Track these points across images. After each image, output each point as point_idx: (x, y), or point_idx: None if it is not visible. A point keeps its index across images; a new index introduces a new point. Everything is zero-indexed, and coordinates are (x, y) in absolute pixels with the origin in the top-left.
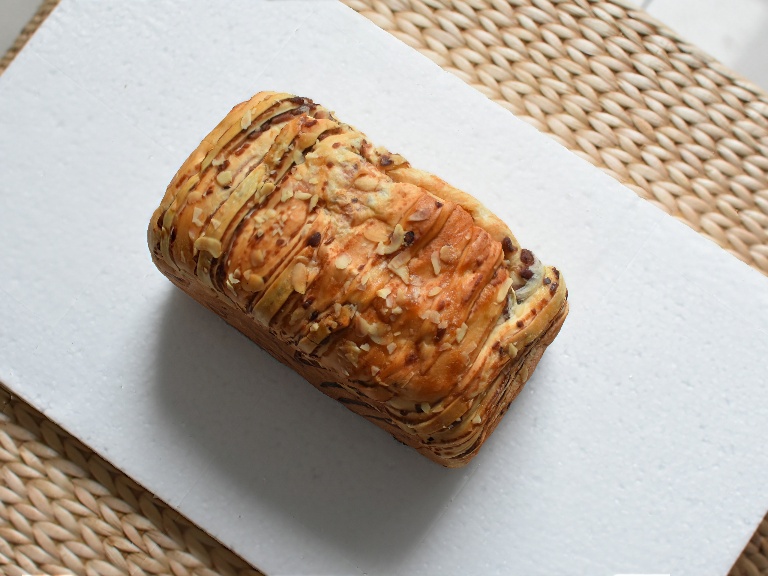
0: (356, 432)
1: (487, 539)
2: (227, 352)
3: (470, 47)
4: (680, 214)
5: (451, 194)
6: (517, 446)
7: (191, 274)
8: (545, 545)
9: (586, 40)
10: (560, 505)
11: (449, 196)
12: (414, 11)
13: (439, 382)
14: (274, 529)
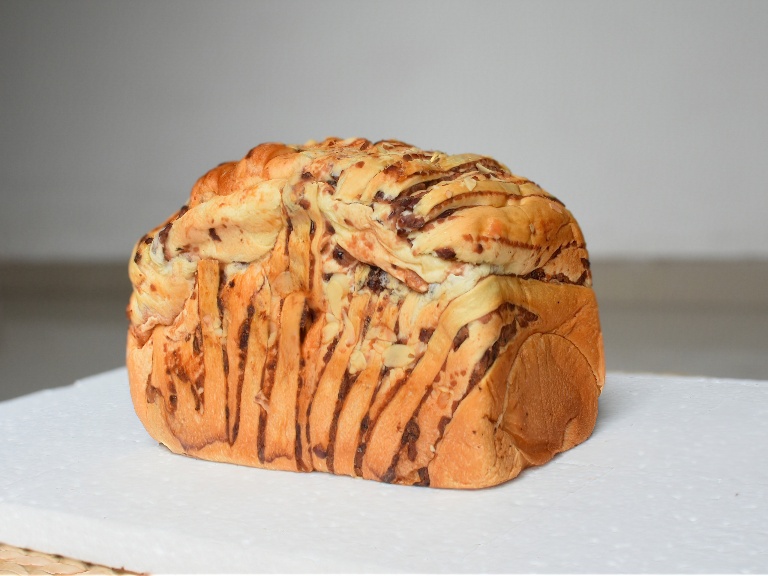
0: None
1: None
2: None
3: None
4: None
5: None
6: None
7: None
8: None
9: None
10: None
11: None
12: None
13: None
14: None
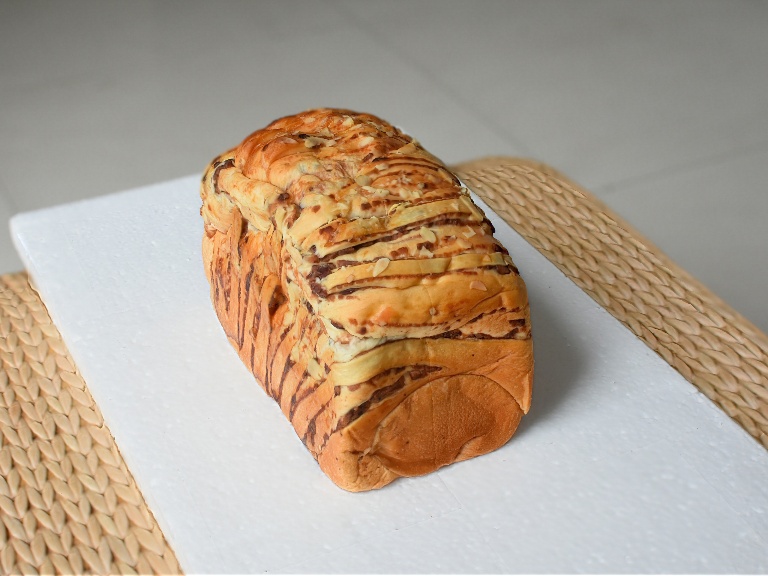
0: None
1: None
2: None
3: (102, 531)
4: (50, 351)
5: None
6: None
7: None
8: None
9: None
10: None
11: None
12: None
13: None
14: None
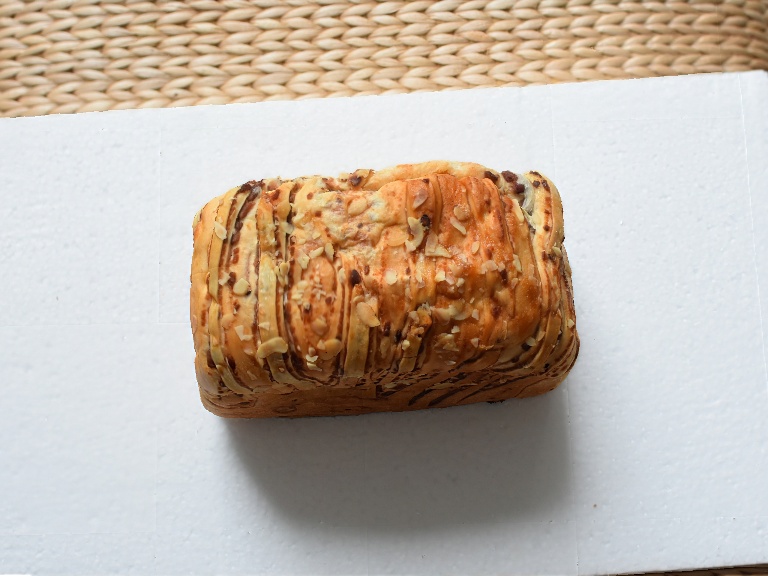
0: (457, 422)
1: (617, 423)
2: (309, 440)
3: (300, 72)
4: (555, 80)
5: (422, 169)
6: (582, 338)
7: (266, 385)
8: (661, 393)
9: (383, 3)
10: (648, 356)
11: (422, 172)
12: (234, 75)
13: (529, 313)
14: (456, 545)
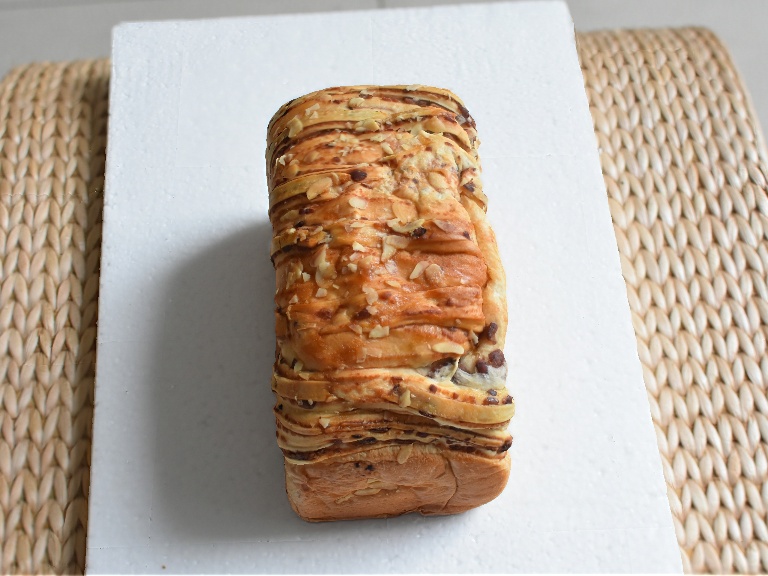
0: (267, 425)
1: None
2: (254, 289)
3: (664, 290)
4: (690, 553)
5: (490, 253)
6: (360, 559)
7: None
8: None
9: (758, 367)
10: None
11: (487, 253)
12: (651, 232)
13: (325, 352)
14: (136, 423)
